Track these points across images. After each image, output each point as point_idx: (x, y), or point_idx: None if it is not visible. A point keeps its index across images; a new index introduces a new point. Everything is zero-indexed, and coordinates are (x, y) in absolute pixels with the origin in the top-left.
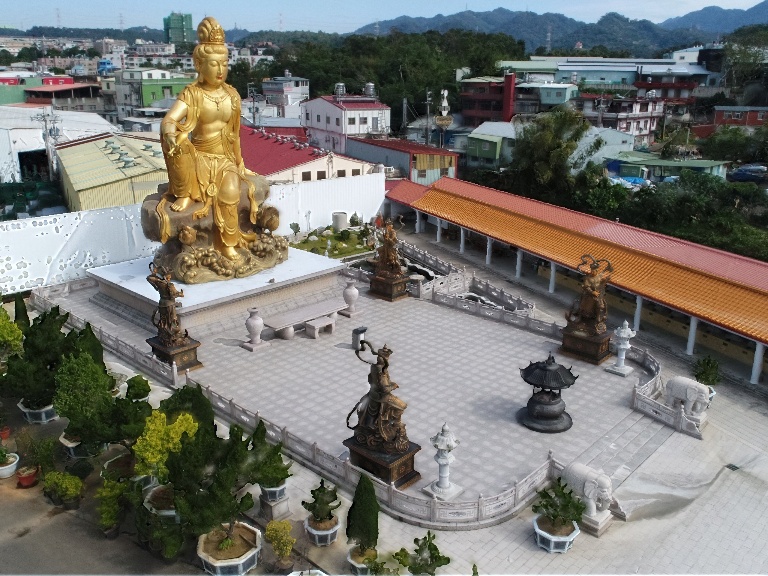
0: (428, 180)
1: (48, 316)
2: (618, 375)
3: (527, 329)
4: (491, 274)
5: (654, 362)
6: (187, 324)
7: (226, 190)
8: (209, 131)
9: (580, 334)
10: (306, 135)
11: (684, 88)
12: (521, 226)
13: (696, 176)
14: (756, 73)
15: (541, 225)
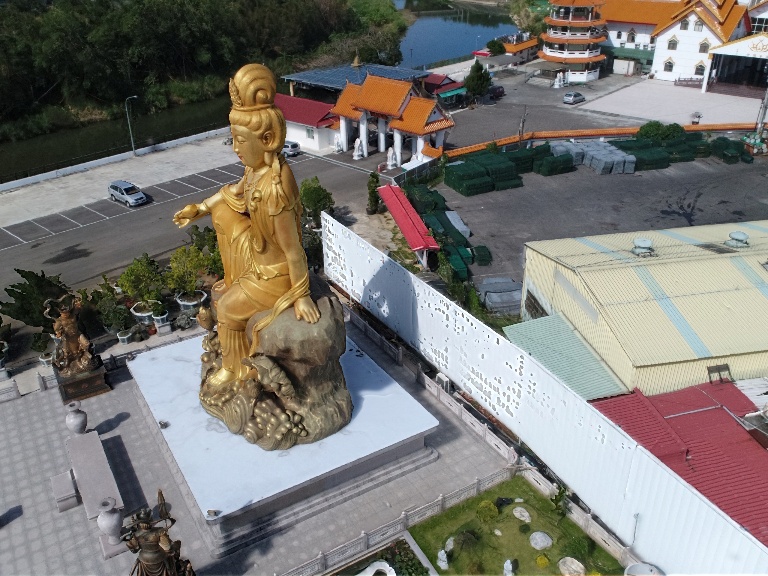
0: None
1: None
2: None
3: None
4: None
5: None
6: None
7: None
8: None
9: None
10: None
11: None
12: None
13: None
14: None
15: None
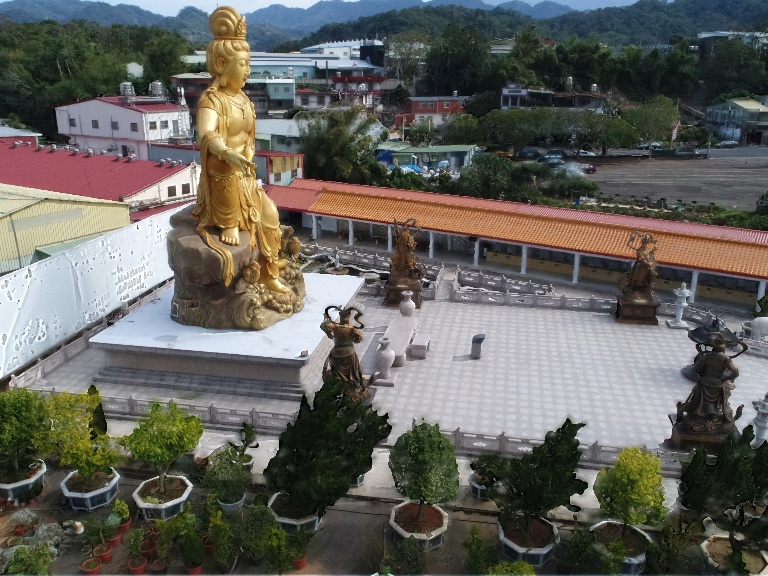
0: (282, 183)
1: (325, 393)
2: (683, 329)
3: (564, 308)
4: (450, 267)
5: (699, 313)
6: (302, 375)
7: (270, 213)
8: (235, 145)
9: (641, 301)
10: (69, 145)
11: (376, 81)
12: (470, 217)
13: (487, 159)
14: (425, 67)
15: (492, 214)
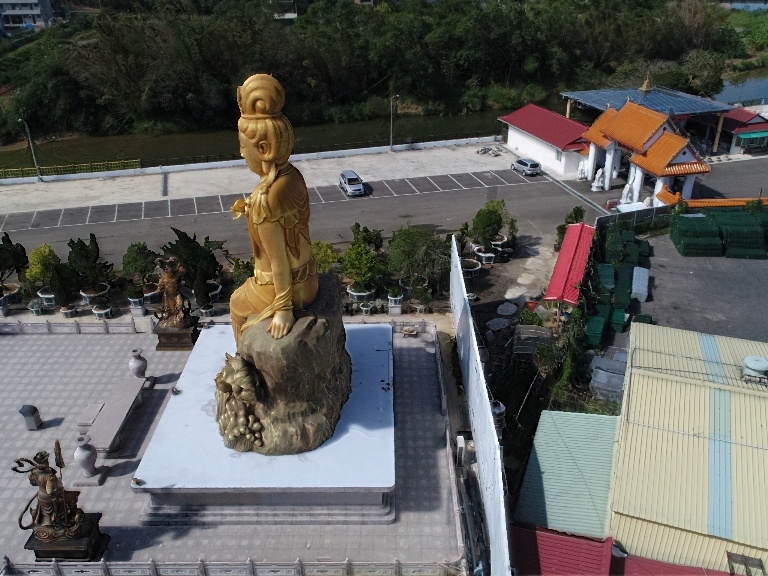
0: None
1: None
2: None
3: None
4: None
5: None
6: None
7: None
8: None
9: None
10: None
11: None
12: None
13: None
14: None
15: None
